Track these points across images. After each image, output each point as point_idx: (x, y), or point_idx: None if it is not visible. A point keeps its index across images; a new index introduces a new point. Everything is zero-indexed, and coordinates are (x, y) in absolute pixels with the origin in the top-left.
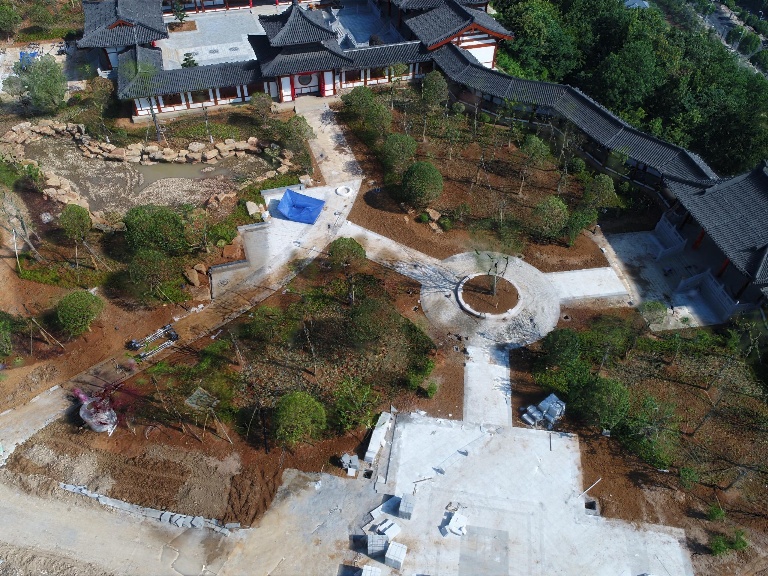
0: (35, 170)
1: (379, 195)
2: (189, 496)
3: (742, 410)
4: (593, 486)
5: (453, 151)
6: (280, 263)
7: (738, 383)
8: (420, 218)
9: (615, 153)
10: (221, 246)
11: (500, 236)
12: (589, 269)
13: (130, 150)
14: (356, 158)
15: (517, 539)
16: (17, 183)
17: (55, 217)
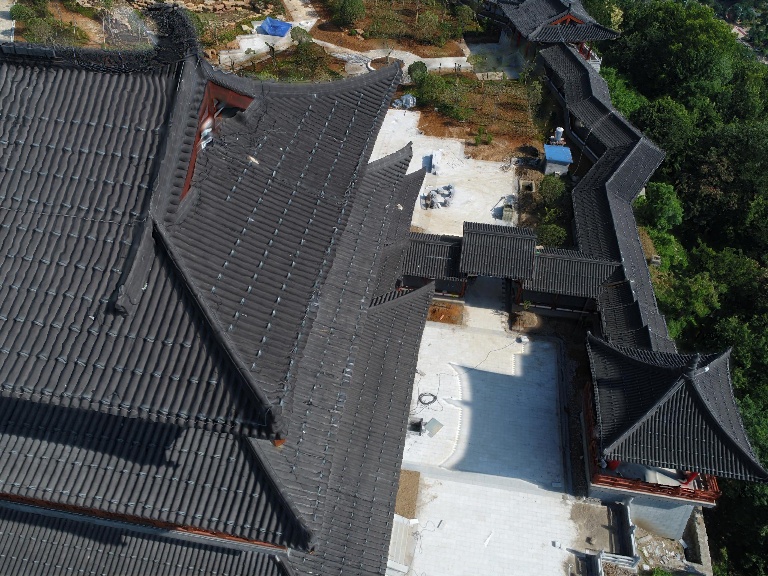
0: (109, 1)
1: (327, 25)
2: None
3: (515, 104)
4: (423, 126)
5: (379, 5)
6: (262, 52)
7: (518, 95)
8: (351, 33)
9: (487, 7)
10: (225, 43)
11: (400, 42)
12: (451, 57)
13: (165, 4)
14: (315, 10)
15: (377, 140)
16: (94, 16)
17: (121, 31)
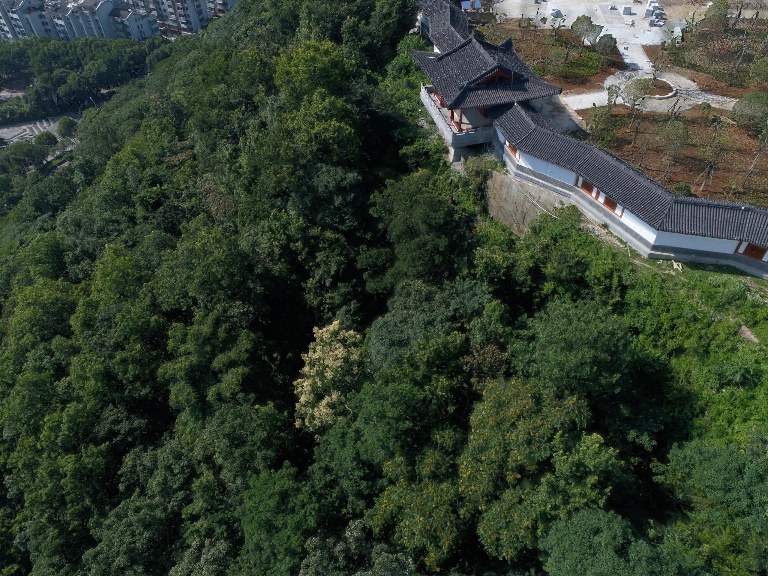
0: None
1: None
2: (740, 18)
3: None
4: None
5: (757, 179)
6: None
7: None
8: None
9: None
10: None
11: None
12: None
13: None
14: None
15: (604, 23)
16: None
17: None
